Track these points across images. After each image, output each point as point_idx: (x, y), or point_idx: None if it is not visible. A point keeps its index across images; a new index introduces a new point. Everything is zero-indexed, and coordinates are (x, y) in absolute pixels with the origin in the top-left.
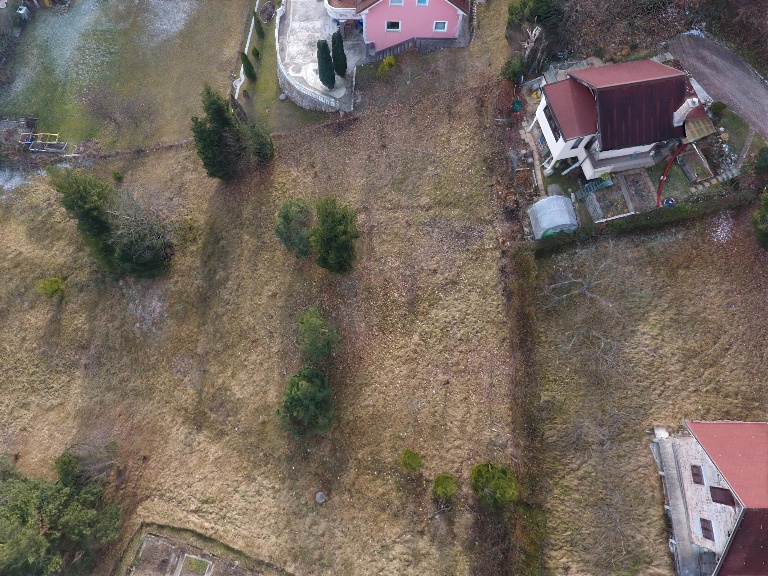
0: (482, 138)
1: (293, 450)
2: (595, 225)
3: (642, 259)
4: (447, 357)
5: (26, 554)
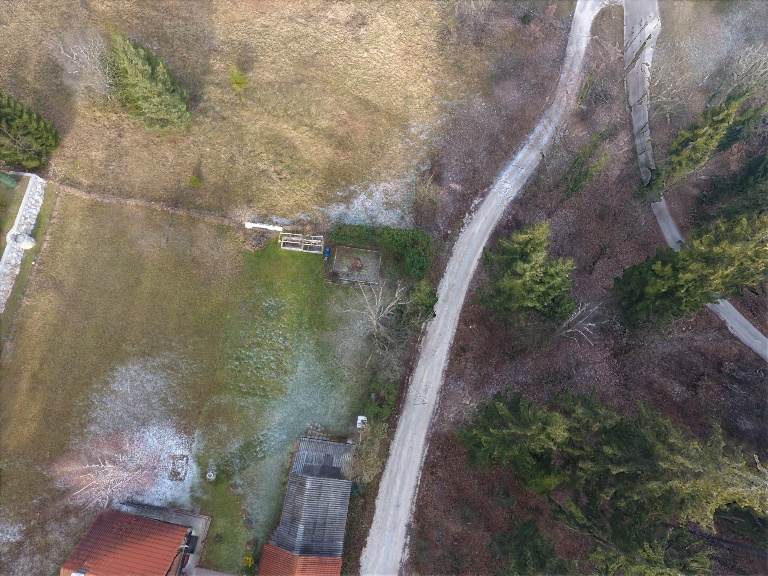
0: None
1: None
2: None
3: None
4: None
5: None
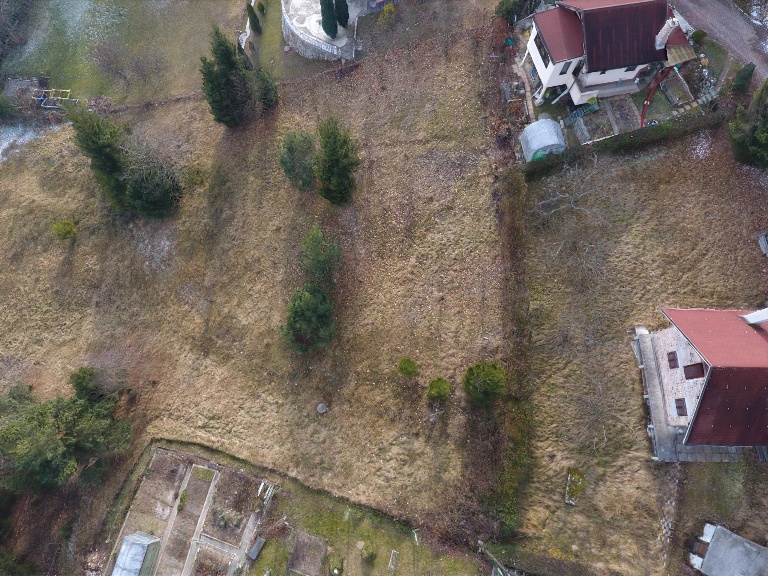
0: (477, 75)
1: (296, 368)
2: (582, 146)
3: (626, 177)
4: (442, 276)
5: (45, 451)
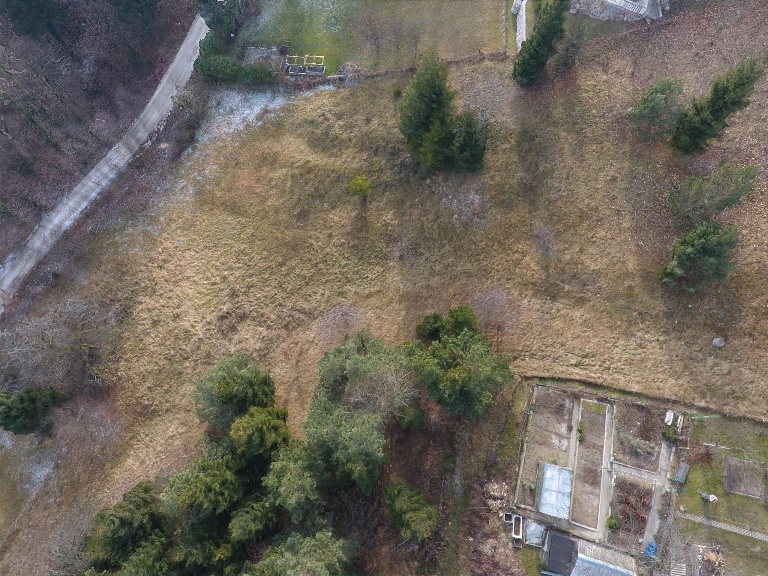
0: None
1: (672, 307)
2: None
3: None
4: None
5: (491, 376)
